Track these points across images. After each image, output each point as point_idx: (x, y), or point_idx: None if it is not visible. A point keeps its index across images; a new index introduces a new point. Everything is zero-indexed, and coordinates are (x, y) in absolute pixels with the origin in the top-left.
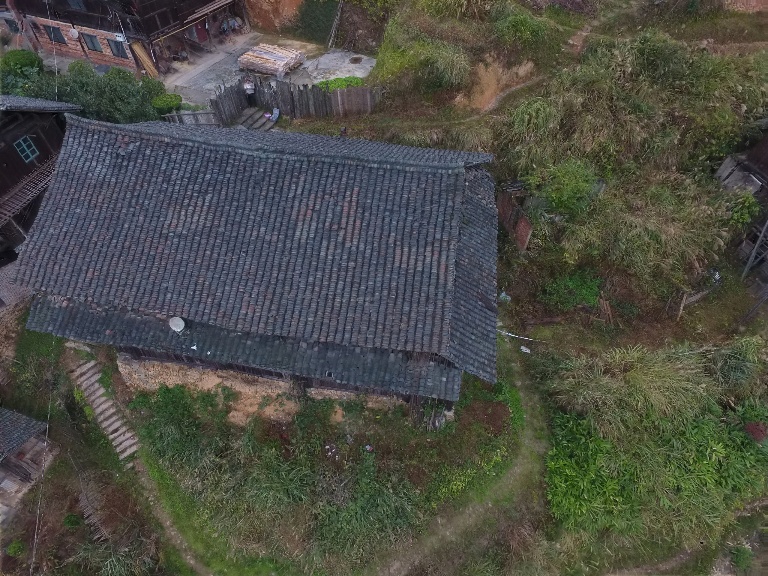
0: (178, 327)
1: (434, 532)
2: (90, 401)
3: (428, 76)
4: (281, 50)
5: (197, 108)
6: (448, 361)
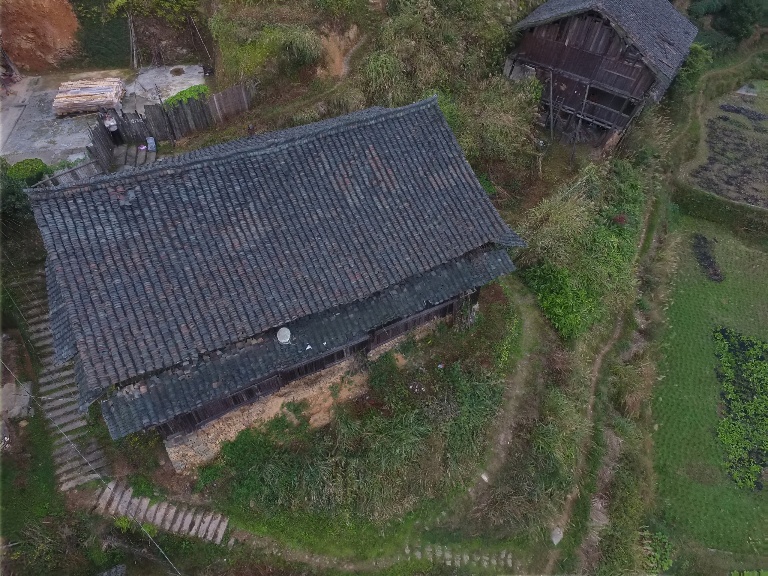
0: (285, 338)
1: (509, 397)
2: (142, 519)
3: (290, 58)
4: (96, 82)
5: (54, 168)
6: (493, 247)
